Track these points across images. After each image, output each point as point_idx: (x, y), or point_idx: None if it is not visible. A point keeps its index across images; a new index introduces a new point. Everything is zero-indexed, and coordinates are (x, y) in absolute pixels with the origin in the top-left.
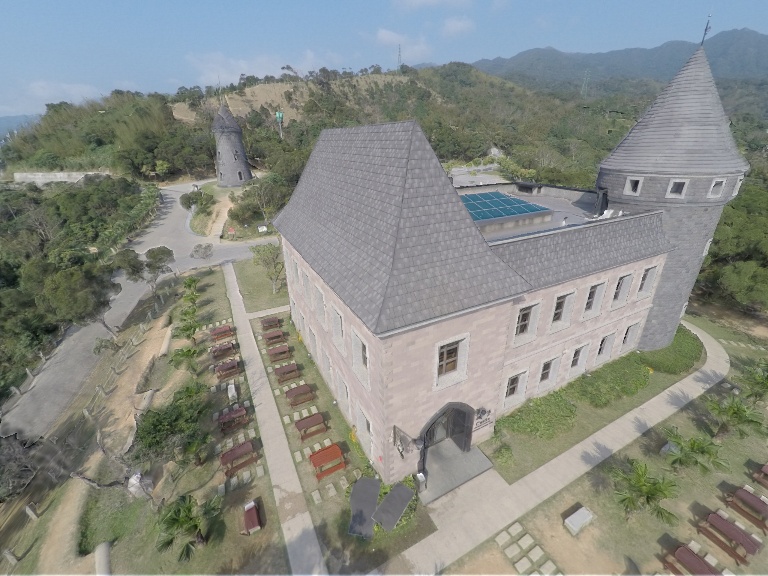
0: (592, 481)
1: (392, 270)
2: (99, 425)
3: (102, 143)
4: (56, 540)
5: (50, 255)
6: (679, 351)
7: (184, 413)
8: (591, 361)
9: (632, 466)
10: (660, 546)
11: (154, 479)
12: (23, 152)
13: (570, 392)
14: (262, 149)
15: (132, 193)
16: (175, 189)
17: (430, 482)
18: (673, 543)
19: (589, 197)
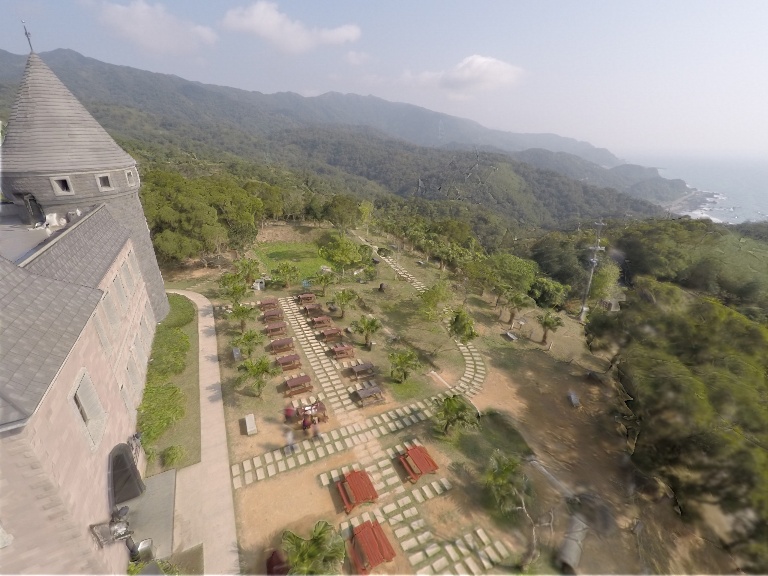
0: (230, 405)
1: None
2: None
3: None
4: None
5: None
6: (179, 307)
7: None
8: (145, 348)
9: (246, 366)
10: (281, 393)
11: None
12: None
13: (154, 380)
14: None
15: None
16: None
17: None
18: (282, 386)
19: None
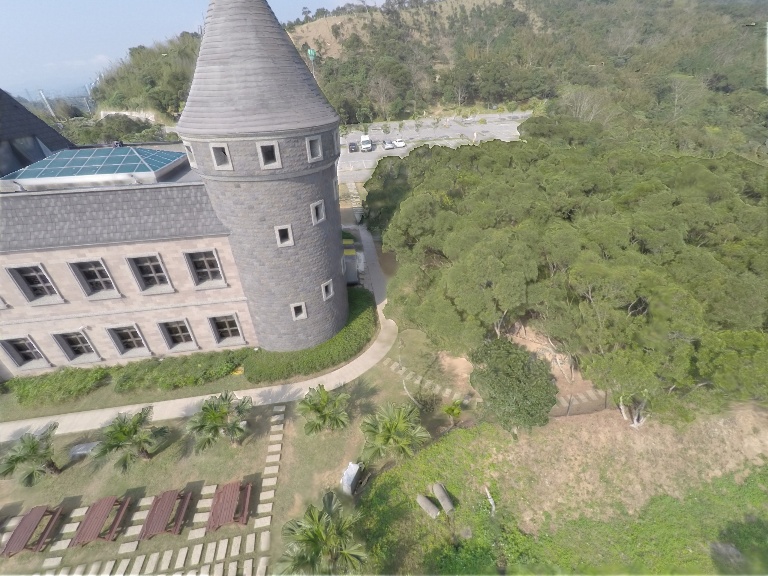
0: None
1: None
2: None
3: (156, 85)
4: None
5: None
6: (297, 359)
7: None
8: (161, 345)
9: None
10: None
11: None
12: (106, 93)
13: (120, 371)
14: None
15: (136, 132)
16: None
17: None
18: None
19: None
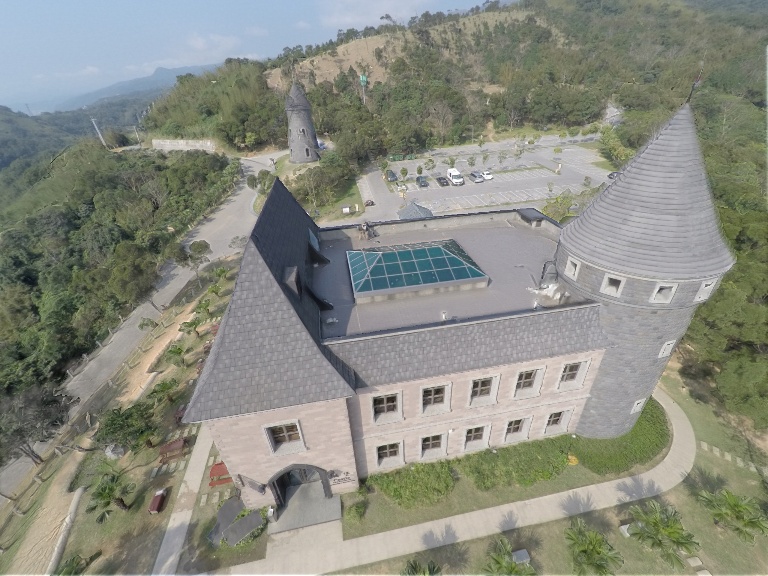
0: None
1: (213, 369)
2: (116, 394)
3: (211, 113)
4: (63, 475)
5: (136, 236)
6: (625, 447)
7: (134, 414)
8: (498, 439)
9: None
10: None
11: (127, 448)
12: (158, 121)
13: (463, 465)
14: (333, 123)
15: (219, 168)
16: (259, 160)
17: (283, 516)
18: None
19: None
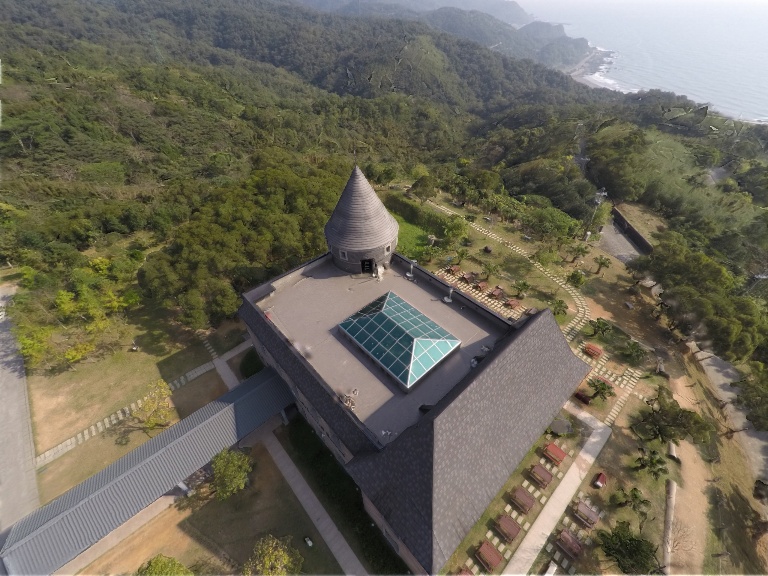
0: None
1: None
2: None
3: None
4: None
5: None
6: None
7: (622, 536)
8: None
9: None
10: None
11: None
12: None
13: None
14: None
15: None
16: None
17: None
18: None
19: (310, 266)
